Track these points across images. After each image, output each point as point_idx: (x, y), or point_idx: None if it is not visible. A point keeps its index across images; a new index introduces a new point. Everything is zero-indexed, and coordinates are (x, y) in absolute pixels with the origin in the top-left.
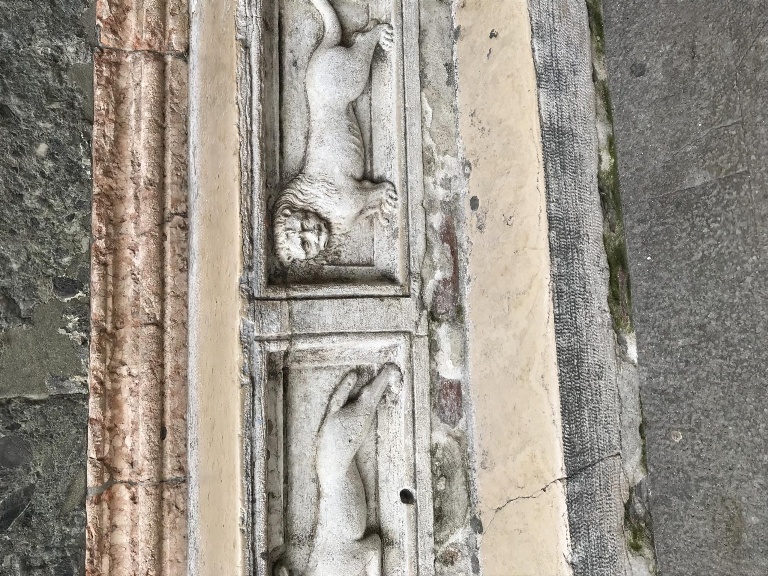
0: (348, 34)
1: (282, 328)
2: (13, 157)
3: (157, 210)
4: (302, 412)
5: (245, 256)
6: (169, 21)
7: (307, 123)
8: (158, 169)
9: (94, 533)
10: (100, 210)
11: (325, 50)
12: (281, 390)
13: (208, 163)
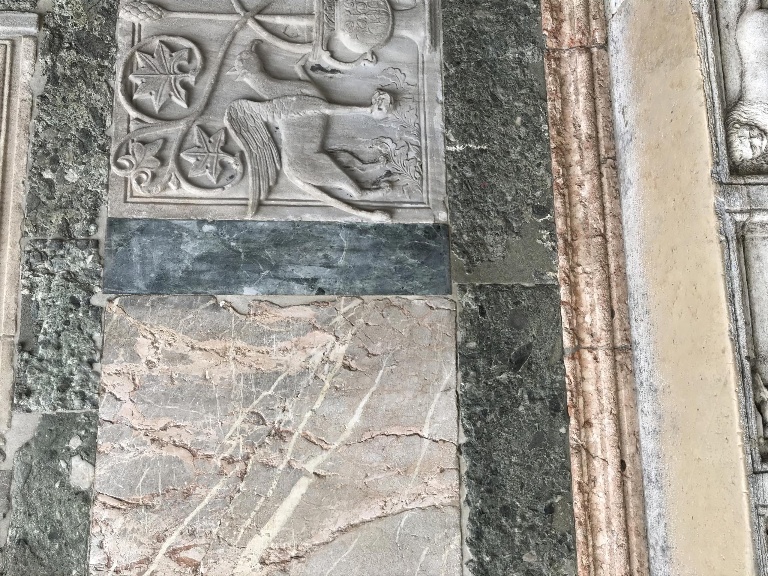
0: (763, 1)
1: (744, 204)
2: (502, 127)
3: (596, 155)
4: (757, 268)
5: (714, 155)
6: (593, 24)
7: (740, 66)
8: (594, 127)
9: (573, 380)
10: (558, 158)
11: (751, 13)
12: (742, 250)
13: (651, 110)
